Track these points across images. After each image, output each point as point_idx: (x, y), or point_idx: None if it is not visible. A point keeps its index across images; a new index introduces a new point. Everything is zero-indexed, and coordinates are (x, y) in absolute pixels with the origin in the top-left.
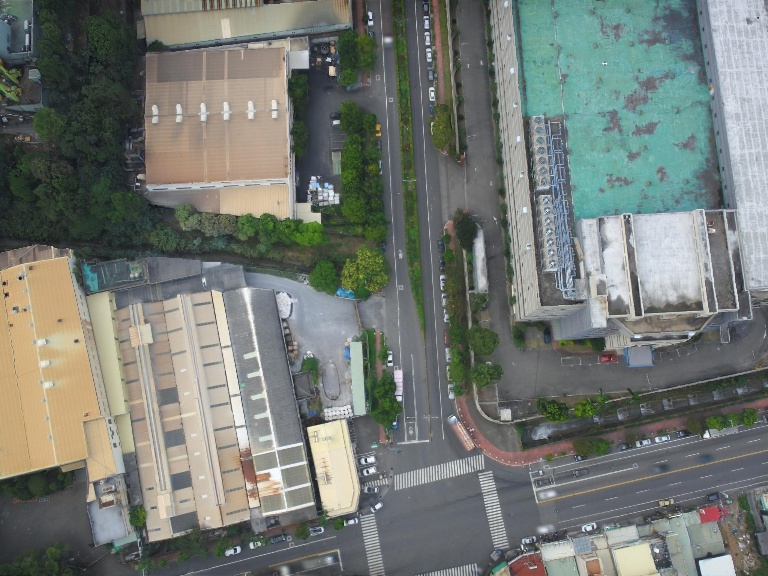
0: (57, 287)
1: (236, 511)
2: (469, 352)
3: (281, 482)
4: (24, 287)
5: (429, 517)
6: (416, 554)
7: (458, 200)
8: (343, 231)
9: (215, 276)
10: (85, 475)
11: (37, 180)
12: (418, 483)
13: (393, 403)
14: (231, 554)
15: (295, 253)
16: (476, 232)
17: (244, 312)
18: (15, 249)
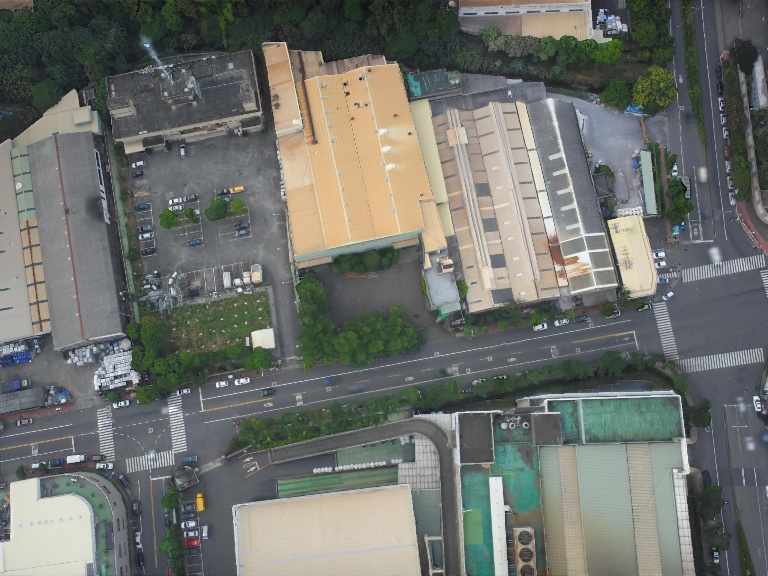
0: (391, 88)
1: (548, 288)
2: (751, 162)
3: (590, 263)
4: (364, 86)
5: (716, 306)
6: (706, 338)
7: (733, 33)
8: (631, 56)
9: (519, 90)
10: (407, 257)
11: (366, 1)
12: (704, 277)
13: (686, 201)
14: (540, 329)
15: (584, 76)
16: (757, 56)
17: (549, 119)
18: (350, 58)
